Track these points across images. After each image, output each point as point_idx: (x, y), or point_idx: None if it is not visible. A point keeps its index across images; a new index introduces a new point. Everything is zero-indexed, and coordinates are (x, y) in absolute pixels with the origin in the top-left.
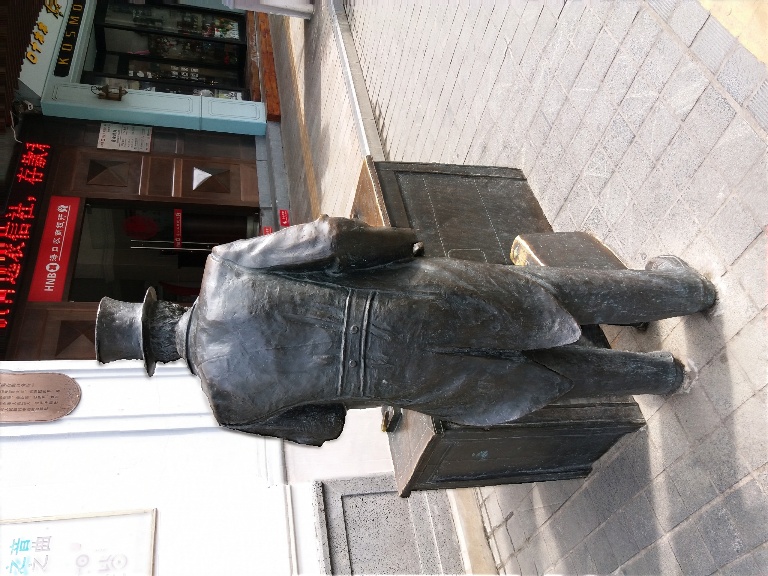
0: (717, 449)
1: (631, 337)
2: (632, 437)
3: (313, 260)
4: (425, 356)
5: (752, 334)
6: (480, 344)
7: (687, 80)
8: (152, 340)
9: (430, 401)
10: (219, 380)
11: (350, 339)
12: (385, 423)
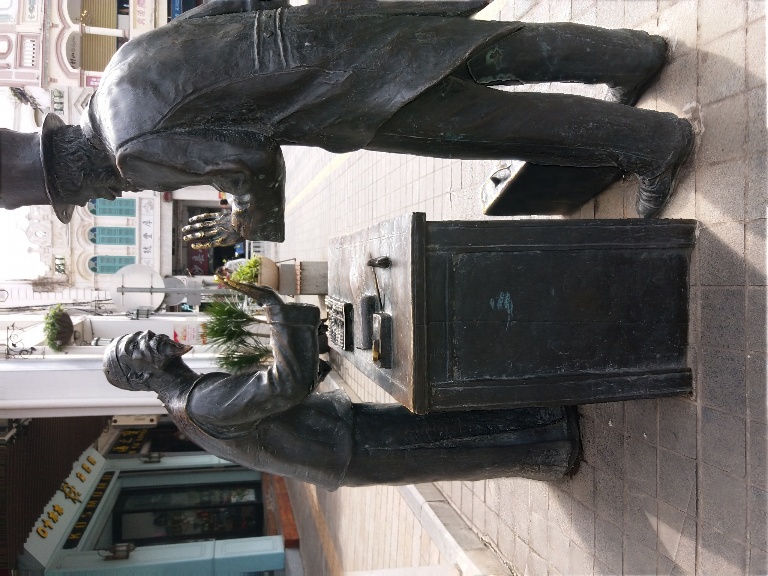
0: (763, 115)
1: (634, 187)
2: (696, 258)
3: (224, 2)
4: (348, 20)
5: (706, 7)
6: (406, 11)
7: (559, 2)
8: (55, 139)
9: (368, 65)
10: (118, 81)
11: (263, 21)
12: (375, 349)
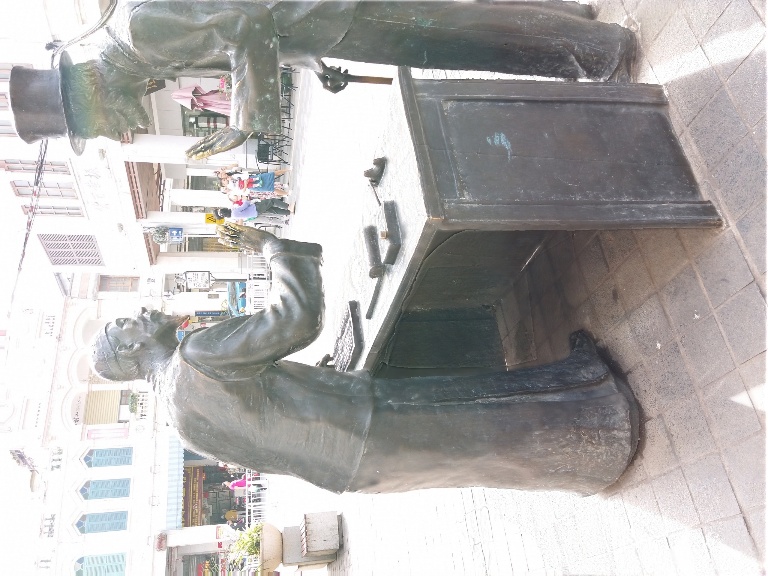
0: None
1: None
2: (674, 111)
3: None
4: None
5: None
6: None
7: None
8: None
9: None
10: None
11: None
12: None
